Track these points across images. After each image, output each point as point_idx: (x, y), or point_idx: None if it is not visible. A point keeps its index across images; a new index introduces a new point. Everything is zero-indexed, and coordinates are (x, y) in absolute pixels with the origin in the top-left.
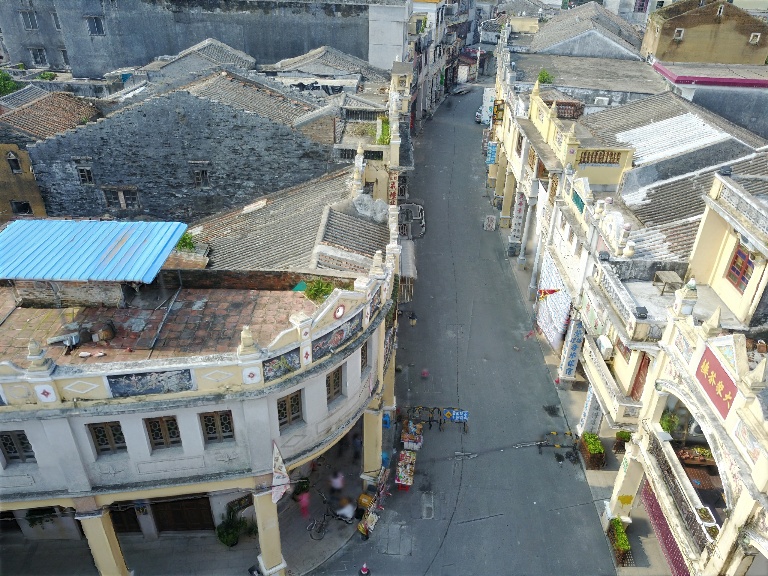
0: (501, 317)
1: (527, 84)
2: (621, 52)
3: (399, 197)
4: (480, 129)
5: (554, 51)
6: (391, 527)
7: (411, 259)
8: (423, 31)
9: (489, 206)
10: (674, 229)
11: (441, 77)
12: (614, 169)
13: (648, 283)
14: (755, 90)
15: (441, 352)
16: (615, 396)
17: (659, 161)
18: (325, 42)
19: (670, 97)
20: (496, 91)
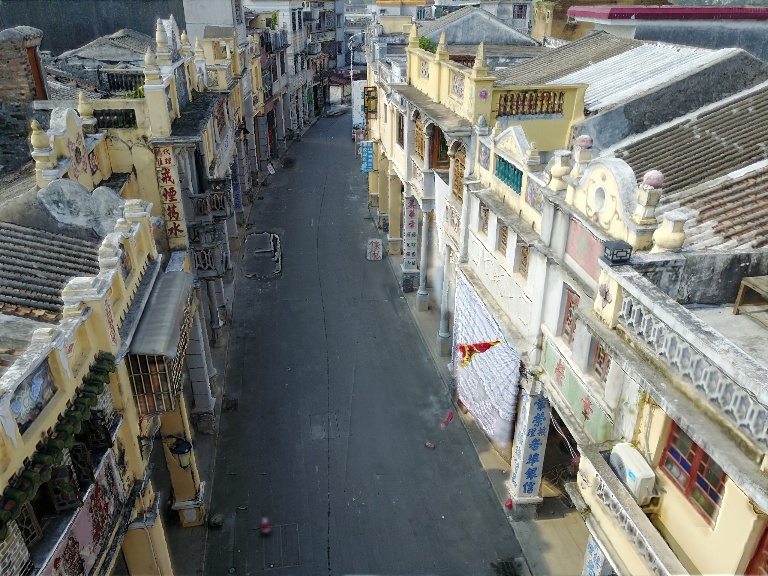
0: (400, 390)
1: (403, 56)
2: (512, 36)
3: (216, 212)
4: None
5: (434, 40)
6: None
7: (172, 311)
8: (273, 29)
9: (373, 229)
10: (709, 196)
11: (309, 96)
12: (555, 123)
13: (721, 310)
14: (714, 24)
15: (299, 472)
16: None
17: (629, 101)
18: (123, 23)
19: (605, 37)
20: (367, 84)
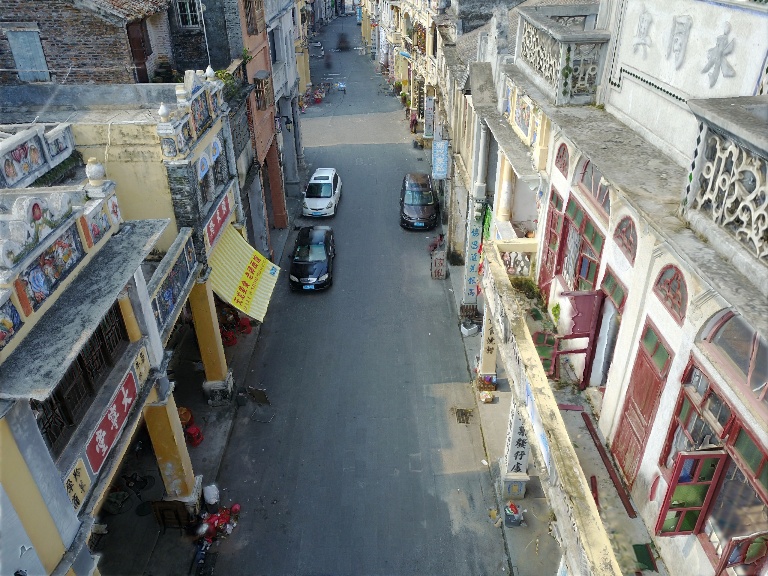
0: None
1: None
2: None
3: None
4: (360, 27)
5: None
6: (313, 108)
7: (310, 8)
8: None
9: None
10: None
11: (332, 2)
12: None
13: None
14: None
15: None
16: (392, 33)
17: None
18: None
19: None
20: None
